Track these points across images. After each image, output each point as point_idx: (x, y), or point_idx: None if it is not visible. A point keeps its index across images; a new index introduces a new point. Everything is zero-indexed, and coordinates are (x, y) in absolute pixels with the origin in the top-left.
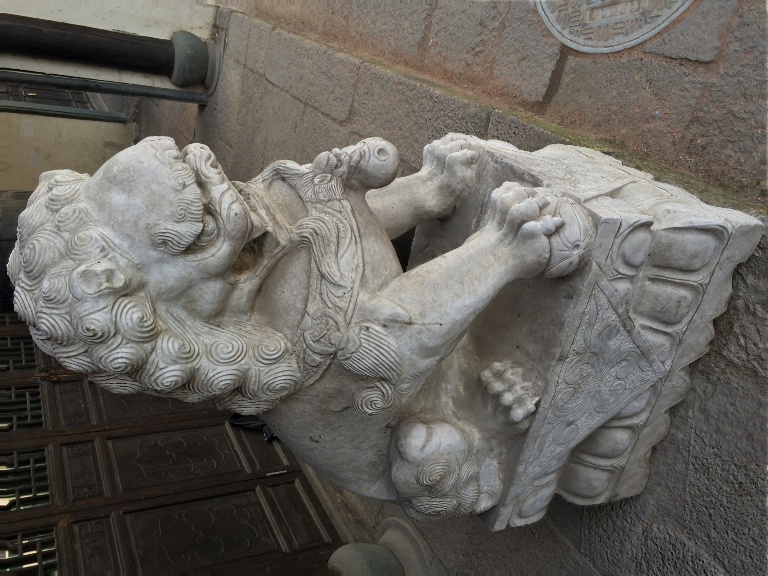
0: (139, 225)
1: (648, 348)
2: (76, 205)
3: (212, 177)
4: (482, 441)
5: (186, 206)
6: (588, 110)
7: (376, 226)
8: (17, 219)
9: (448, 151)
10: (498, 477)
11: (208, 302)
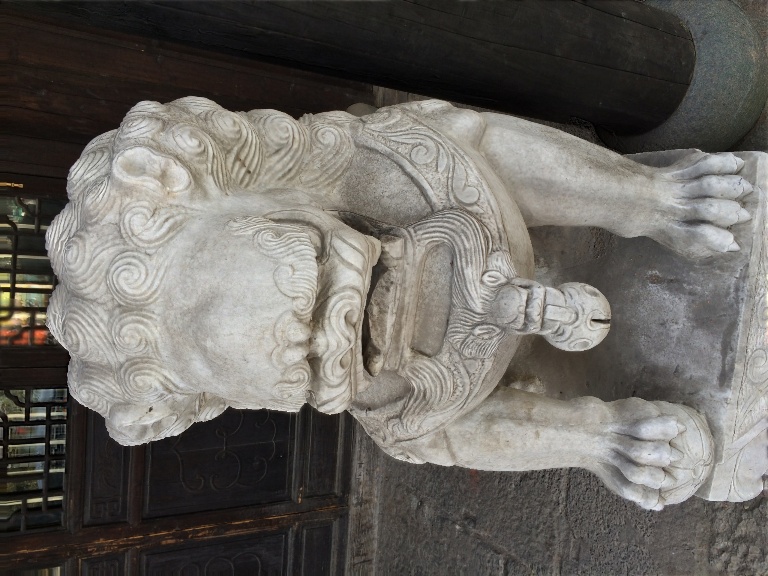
0: None
1: None
2: (144, 331)
3: (332, 380)
4: None
5: None
6: None
7: (509, 358)
8: None
9: (715, 218)
10: None
11: None
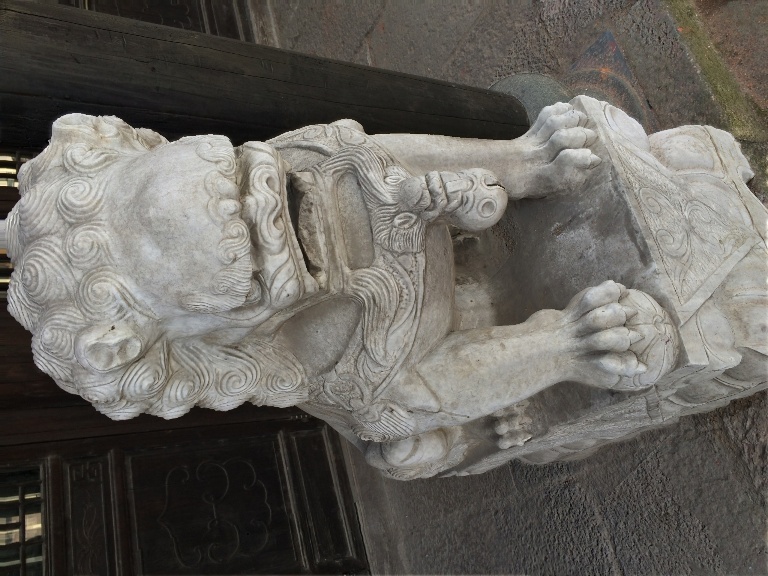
0: (169, 290)
1: (658, 415)
2: (95, 235)
3: (272, 243)
4: (462, 438)
5: (231, 285)
6: (759, 52)
7: (445, 274)
8: (19, 65)
9: (568, 141)
10: (463, 453)
11: (231, 340)
